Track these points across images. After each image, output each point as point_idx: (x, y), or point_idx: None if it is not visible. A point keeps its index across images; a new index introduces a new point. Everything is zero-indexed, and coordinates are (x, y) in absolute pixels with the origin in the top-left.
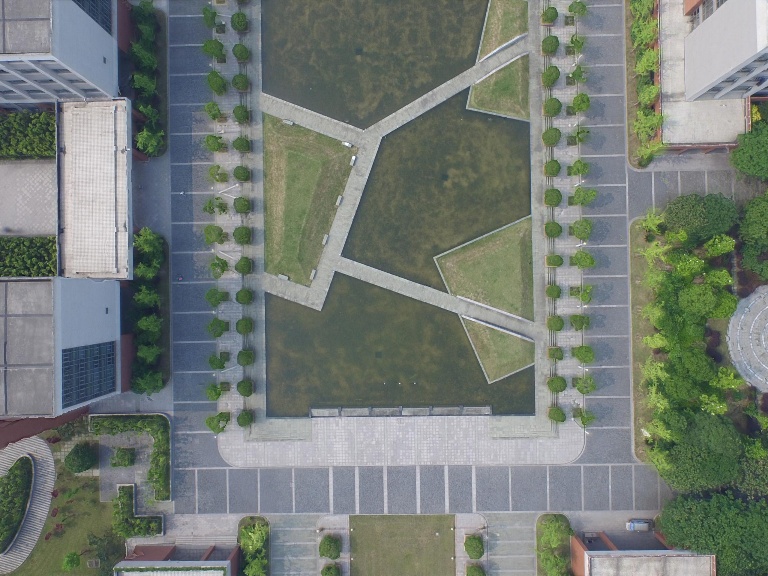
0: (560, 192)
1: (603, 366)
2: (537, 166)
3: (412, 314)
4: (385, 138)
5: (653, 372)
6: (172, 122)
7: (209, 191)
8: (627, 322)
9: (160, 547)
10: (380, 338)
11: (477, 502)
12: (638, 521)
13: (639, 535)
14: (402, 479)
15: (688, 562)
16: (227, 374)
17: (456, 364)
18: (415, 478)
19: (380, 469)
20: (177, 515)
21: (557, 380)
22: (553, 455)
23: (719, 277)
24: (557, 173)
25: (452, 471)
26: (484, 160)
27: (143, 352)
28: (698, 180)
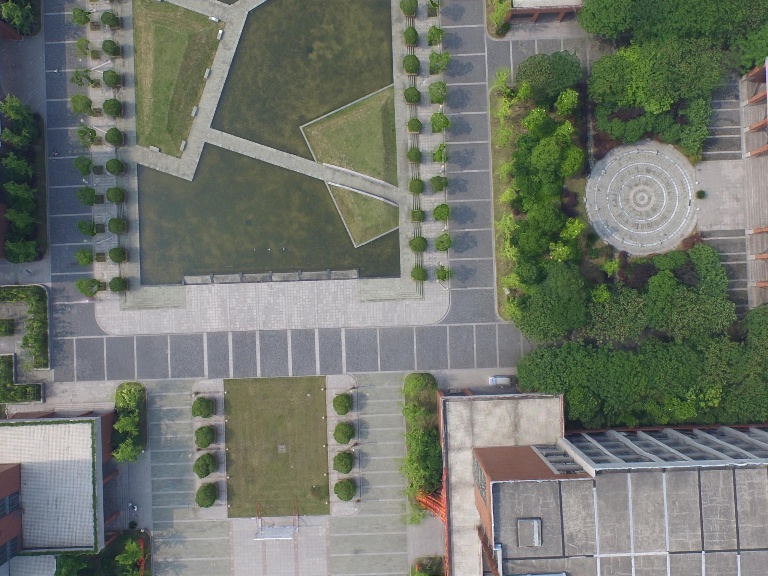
0: (418, 59)
1: (466, 229)
2: (398, 36)
3: (280, 183)
4: (251, 13)
5: (503, 223)
6: (45, 2)
7: (82, 68)
8: (489, 186)
9: (39, 413)
10: (250, 207)
11: (347, 363)
12: (501, 376)
13: (502, 390)
14: (274, 343)
15: (539, 404)
16: (103, 245)
17: (324, 230)
18: (287, 342)
19: (253, 334)
20: (56, 383)
21: (416, 238)
22: (419, 316)
23: (564, 129)
24: (415, 41)
25: (322, 334)
26: (347, 32)
27: (10, 214)
28: (554, 48)
